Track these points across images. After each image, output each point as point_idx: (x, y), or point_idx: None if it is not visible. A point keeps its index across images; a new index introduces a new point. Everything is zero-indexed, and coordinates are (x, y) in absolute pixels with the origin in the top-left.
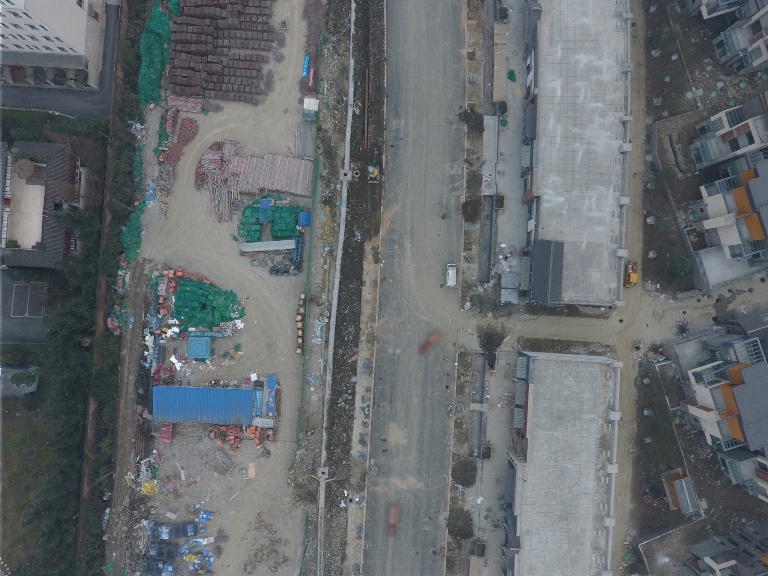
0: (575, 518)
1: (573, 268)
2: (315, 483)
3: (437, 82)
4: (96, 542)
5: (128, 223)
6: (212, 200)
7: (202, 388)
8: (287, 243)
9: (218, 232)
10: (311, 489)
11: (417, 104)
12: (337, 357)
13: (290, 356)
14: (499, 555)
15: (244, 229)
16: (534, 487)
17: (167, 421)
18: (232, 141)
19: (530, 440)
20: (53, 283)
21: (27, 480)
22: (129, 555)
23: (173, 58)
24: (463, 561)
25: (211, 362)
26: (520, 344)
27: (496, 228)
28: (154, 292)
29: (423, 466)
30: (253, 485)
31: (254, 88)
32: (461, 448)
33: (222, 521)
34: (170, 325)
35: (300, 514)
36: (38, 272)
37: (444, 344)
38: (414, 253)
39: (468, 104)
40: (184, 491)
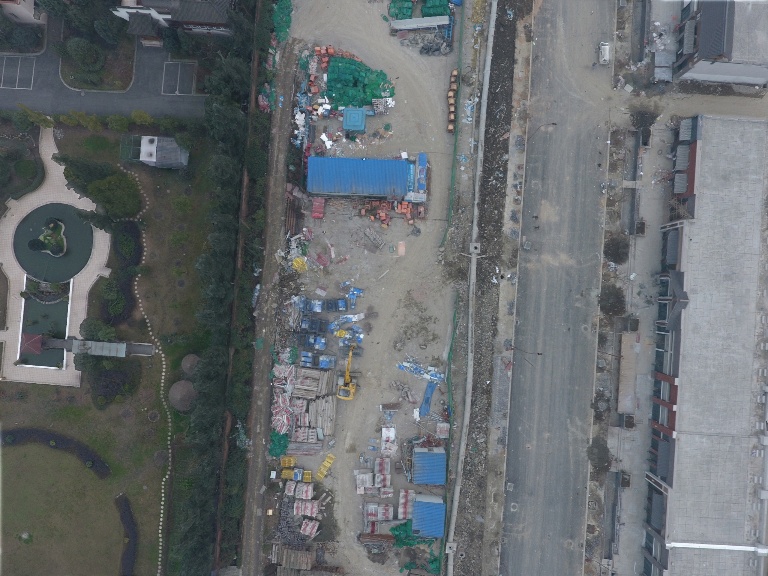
0: (740, 278)
1: (739, 30)
2: (466, 261)
3: None
4: (248, 315)
5: (279, 1)
6: None
7: (357, 159)
8: (440, 19)
9: (368, 12)
10: (462, 267)
11: None
12: (488, 136)
13: (440, 136)
14: (652, 331)
15: (395, 7)
16: (699, 247)
17: (322, 192)
18: None
19: (698, 197)
20: (204, 60)
21: (178, 256)
22: (279, 331)
23: None
24: (615, 338)
25: (361, 141)
26: (673, 123)
27: (649, 7)
28: (304, 71)
29: (575, 243)
30: (403, 263)
31: None
32: (613, 226)
33: (372, 298)
34: (320, 104)
35: (450, 292)
36: (190, 48)
37: (596, 122)
38: (567, 32)
39: None
40: (334, 268)
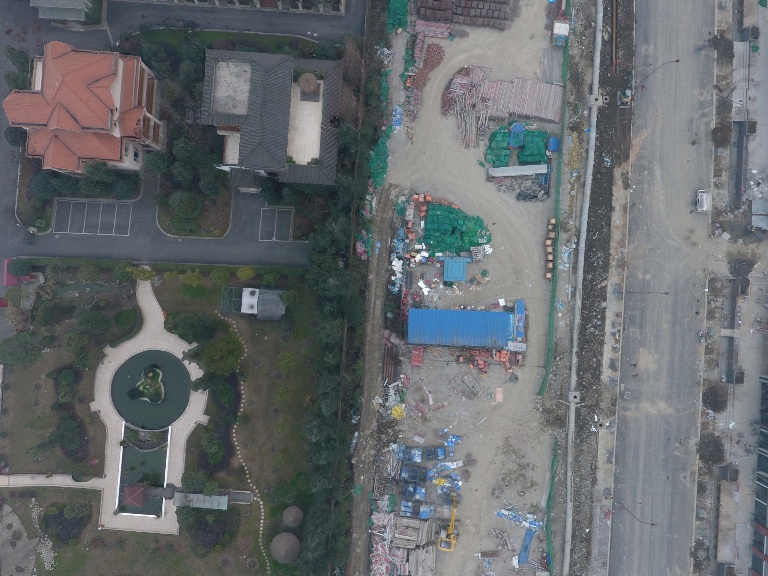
0: None
1: None
2: (564, 408)
3: (686, 8)
4: (348, 464)
5: (375, 148)
6: (459, 125)
7: None
8: (539, 167)
9: (464, 158)
10: (560, 414)
11: (666, 30)
12: (586, 283)
13: (537, 282)
14: (751, 480)
15: (493, 154)
16: None
17: (423, 343)
18: (478, 67)
19: None
20: (302, 207)
21: (275, 403)
22: (377, 478)
23: None
24: (714, 486)
25: (458, 287)
26: None
27: (746, 154)
28: (400, 217)
29: (674, 391)
30: (501, 410)
31: (503, 13)
32: (712, 374)
33: (470, 445)
34: (417, 250)
35: (548, 439)
36: None
37: (694, 270)
38: (664, 179)
39: (717, 30)
40: (432, 415)
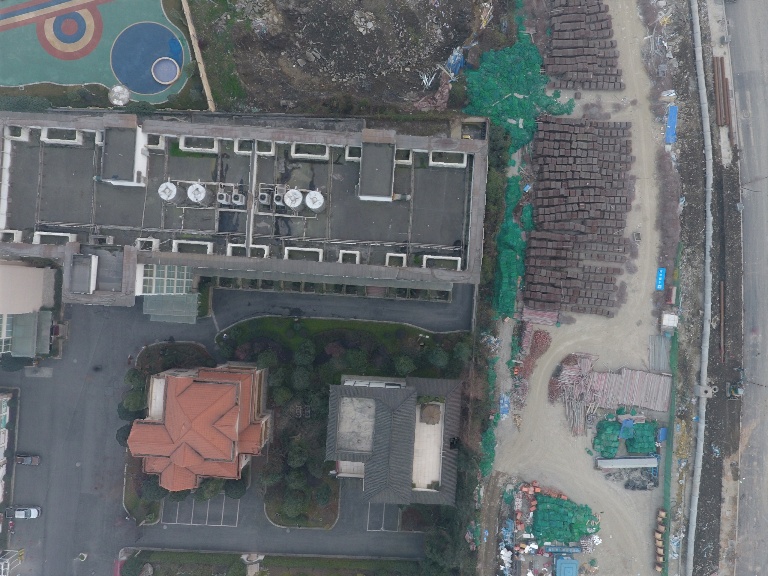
0: None
1: None
2: None
3: None
4: None
5: (483, 437)
6: (567, 414)
7: None
8: (649, 461)
9: (572, 445)
10: None
11: None
12: (695, 573)
13: (646, 571)
14: None
15: (601, 445)
16: None
17: None
18: (585, 354)
19: None
20: None
21: None
22: None
23: (532, 274)
24: None
25: None
26: None
27: None
28: (508, 506)
29: None
30: None
31: (611, 302)
32: None
33: None
34: (525, 539)
35: None
36: None
37: None
38: None
39: None
40: None
